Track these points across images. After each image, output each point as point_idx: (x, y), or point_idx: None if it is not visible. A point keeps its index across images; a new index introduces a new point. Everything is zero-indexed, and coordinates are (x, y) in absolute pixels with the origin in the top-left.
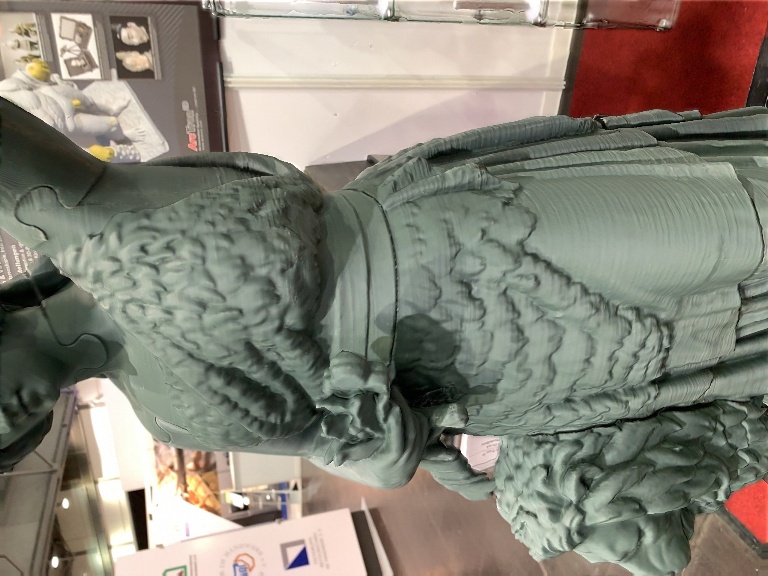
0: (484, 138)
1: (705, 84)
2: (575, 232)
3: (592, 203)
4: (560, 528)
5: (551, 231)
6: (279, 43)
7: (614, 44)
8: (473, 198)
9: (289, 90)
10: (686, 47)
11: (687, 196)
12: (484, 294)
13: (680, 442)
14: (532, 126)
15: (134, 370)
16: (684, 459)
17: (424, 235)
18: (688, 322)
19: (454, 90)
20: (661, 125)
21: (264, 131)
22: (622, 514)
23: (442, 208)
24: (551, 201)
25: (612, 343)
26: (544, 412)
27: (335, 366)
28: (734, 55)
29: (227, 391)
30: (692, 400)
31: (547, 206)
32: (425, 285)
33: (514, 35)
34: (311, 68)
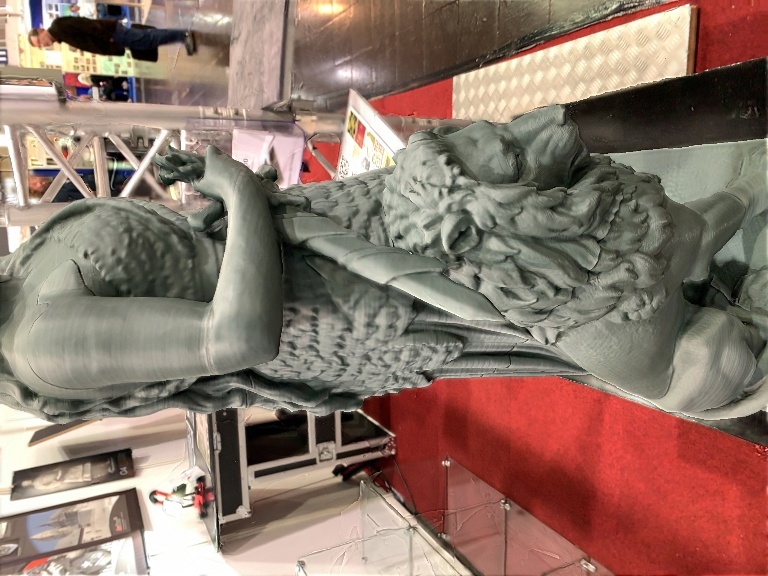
0: None
1: None
2: None
3: None
4: None
5: None
6: None
7: None
8: None
9: None
10: None
11: None
12: None
13: None
14: None
15: (30, 271)
16: None
17: None
18: None
19: None
20: None
21: None
22: None
23: None
24: None
25: None
26: None
27: None
28: (734, 567)
29: None
30: None
31: None
32: None
33: None
34: None
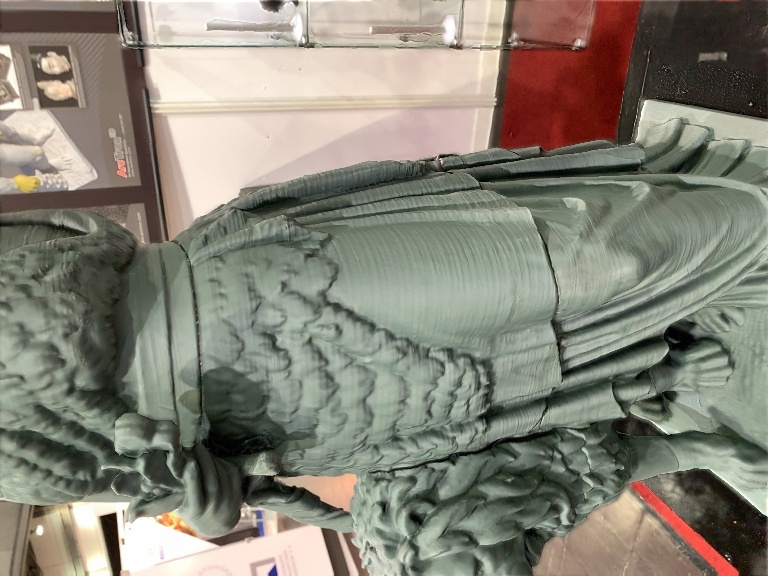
0: (310, 186)
1: (618, 101)
2: (374, 281)
3: (393, 252)
4: (395, 564)
5: (351, 281)
6: (206, 68)
7: (537, 62)
8: (278, 251)
9: (220, 114)
10: (600, 66)
11: (483, 242)
12: (288, 345)
13: (516, 472)
14: (359, 172)
15: None
16: (515, 490)
17: (225, 290)
18: (507, 359)
19: (386, 110)
20: (494, 165)
21: (195, 155)
22: (451, 548)
23: (245, 262)
24: (355, 251)
25: (425, 384)
26: (372, 452)
27: (117, 428)
28: None
29: (22, 454)
30: (526, 431)
31: (350, 256)
32: (226, 339)
33: (443, 55)
34: (241, 92)
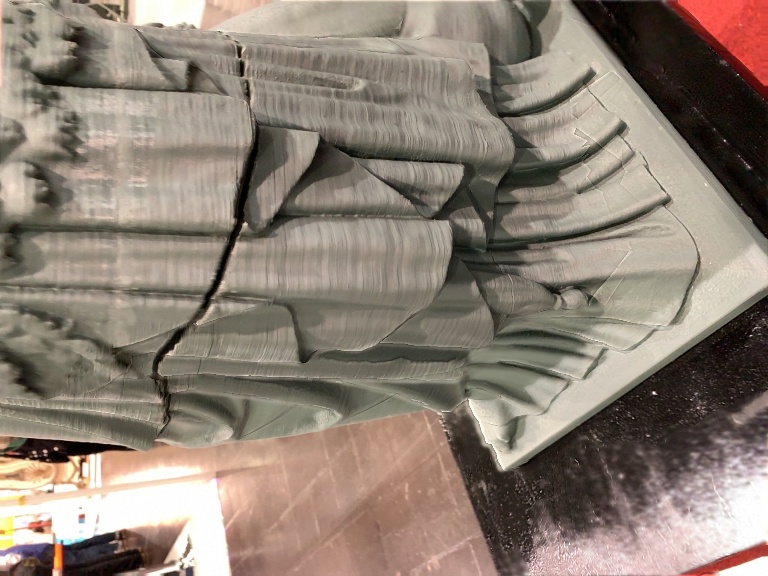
0: None
1: None
2: None
3: None
4: None
5: None
6: None
7: None
8: None
9: None
10: None
11: None
12: None
13: None
14: None
15: None
16: None
17: None
18: None
19: None
20: (239, 372)
21: None
22: None
23: None
24: None
25: None
26: None
27: None
28: None
29: None
30: None
31: None
32: None
33: None
34: None
